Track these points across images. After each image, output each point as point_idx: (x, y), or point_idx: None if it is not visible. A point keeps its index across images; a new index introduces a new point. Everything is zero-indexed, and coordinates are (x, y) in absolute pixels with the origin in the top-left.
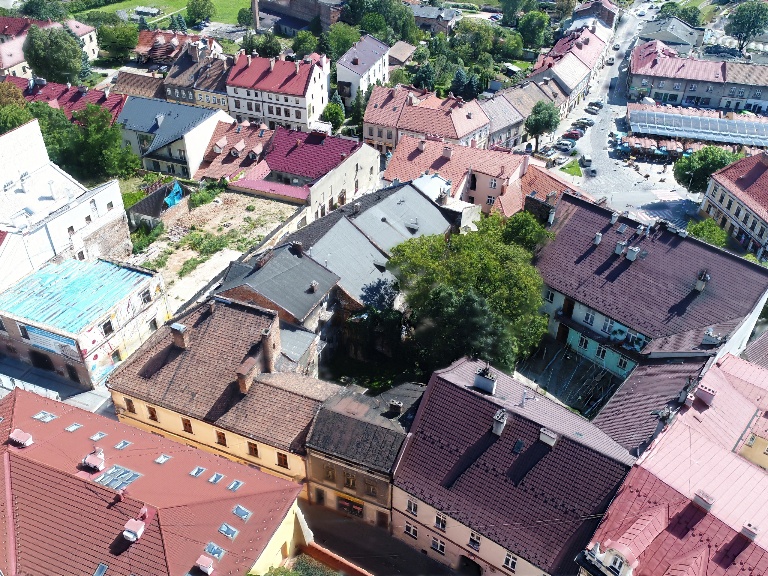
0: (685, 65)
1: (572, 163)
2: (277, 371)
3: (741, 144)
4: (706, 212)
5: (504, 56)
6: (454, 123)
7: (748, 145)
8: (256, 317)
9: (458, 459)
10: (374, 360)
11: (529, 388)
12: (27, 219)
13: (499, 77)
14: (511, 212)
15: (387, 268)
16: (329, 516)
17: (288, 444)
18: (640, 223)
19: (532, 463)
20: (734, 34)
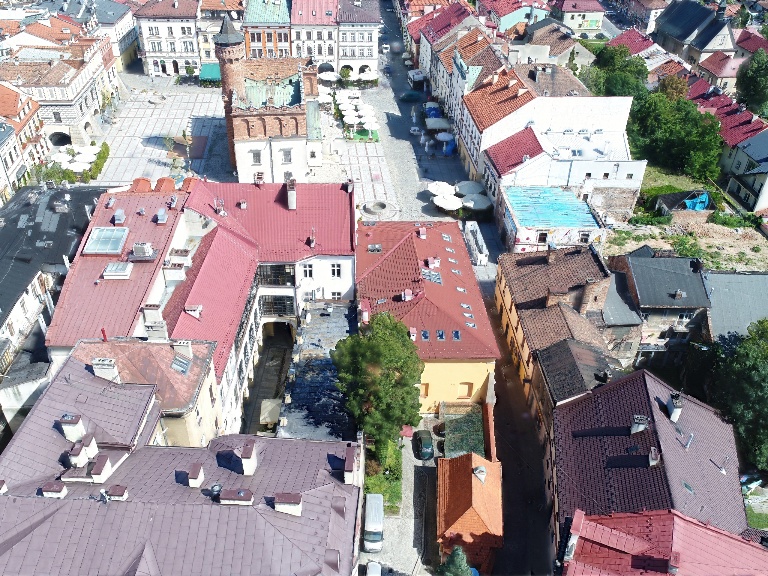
0: None
1: None
2: (586, 317)
3: None
4: None
5: None
6: None
7: None
8: (598, 270)
9: (597, 427)
10: (692, 391)
11: (738, 469)
12: (575, 157)
13: None
14: None
15: None
16: (528, 419)
17: (535, 348)
18: None
19: (628, 464)
20: None
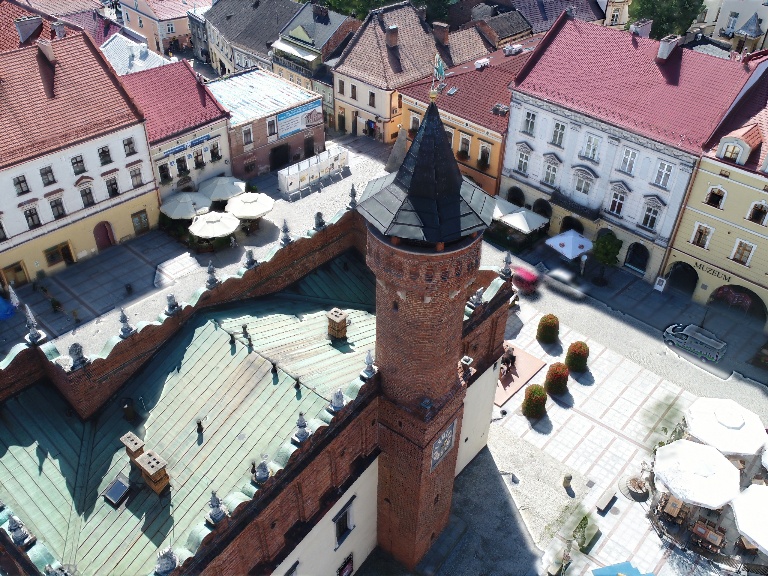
0: None
1: None
2: None
3: None
4: None
5: None
6: None
7: None
8: (403, 9)
9: (539, 7)
10: None
11: None
12: None
13: None
14: None
15: (339, 8)
16: None
17: (487, 51)
18: None
19: None
20: None
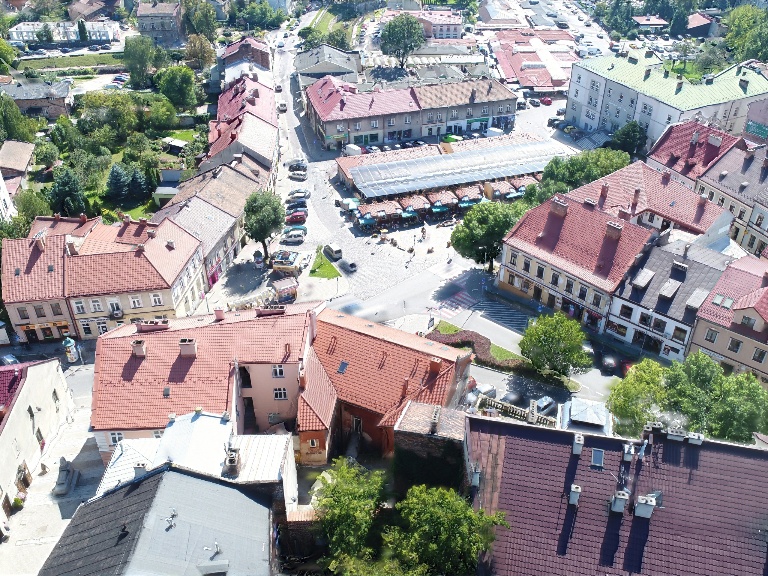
0: (374, 100)
1: (318, 260)
2: None
3: (483, 181)
4: (509, 284)
5: (156, 129)
6: (154, 265)
7: (490, 180)
8: None
9: None
10: None
11: None
12: None
13: (164, 159)
14: (328, 413)
15: None
16: None
17: None
18: (621, 440)
19: None
20: (392, 52)
